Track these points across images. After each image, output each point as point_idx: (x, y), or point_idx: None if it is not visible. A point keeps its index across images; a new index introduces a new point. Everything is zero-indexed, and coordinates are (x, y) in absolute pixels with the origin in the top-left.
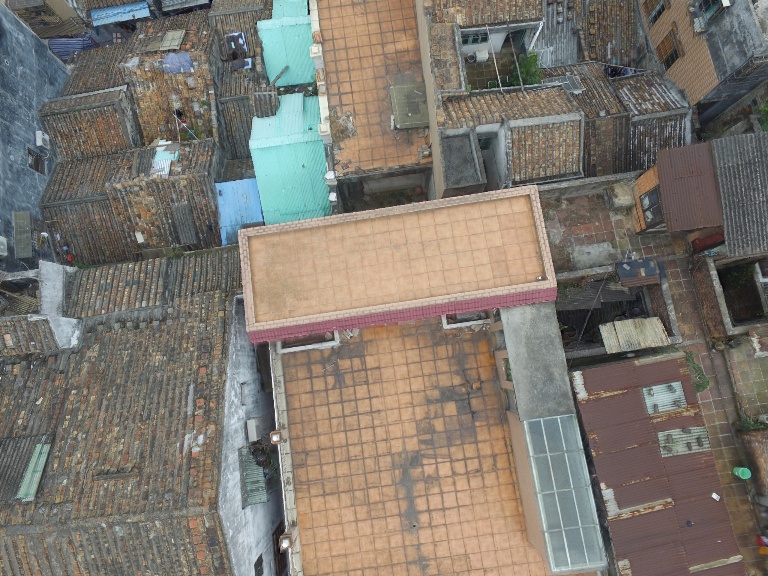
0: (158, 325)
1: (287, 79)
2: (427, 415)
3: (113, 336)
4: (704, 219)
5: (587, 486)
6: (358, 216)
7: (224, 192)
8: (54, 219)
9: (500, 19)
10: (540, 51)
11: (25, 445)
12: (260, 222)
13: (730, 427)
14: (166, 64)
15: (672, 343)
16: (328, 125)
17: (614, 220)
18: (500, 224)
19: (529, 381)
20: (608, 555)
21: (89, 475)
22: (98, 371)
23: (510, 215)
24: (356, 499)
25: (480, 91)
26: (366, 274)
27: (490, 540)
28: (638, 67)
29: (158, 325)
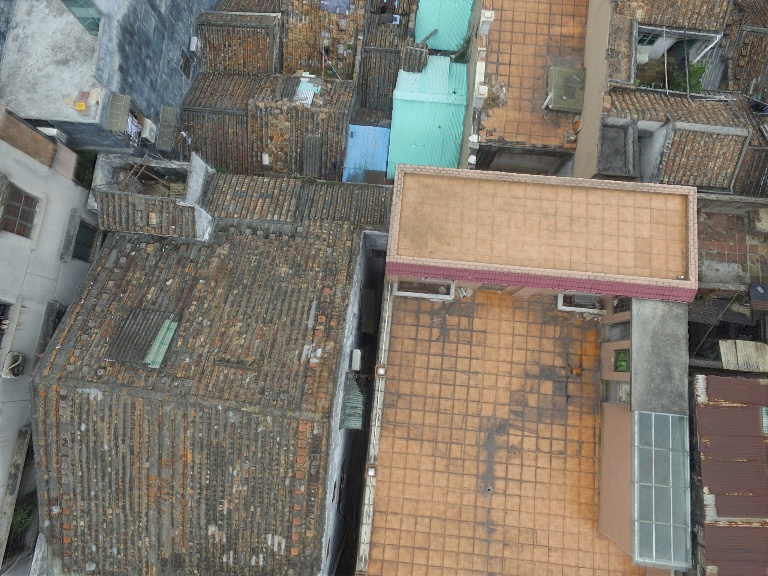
0: (287, 240)
1: (432, 42)
2: (523, 388)
3: (243, 240)
4: None
5: (686, 488)
6: (515, 177)
7: (355, 135)
8: (190, 123)
9: (679, 24)
10: None
11: (154, 318)
12: (383, 171)
13: None
14: (324, 1)
15: None
16: (487, 89)
17: (750, 244)
18: (652, 217)
19: (648, 374)
20: (694, 558)
21: (211, 359)
22: (226, 268)
23: (663, 211)
24: (438, 450)
25: (645, 89)
26: (510, 234)
27: (560, 521)
28: None
29: (287, 240)
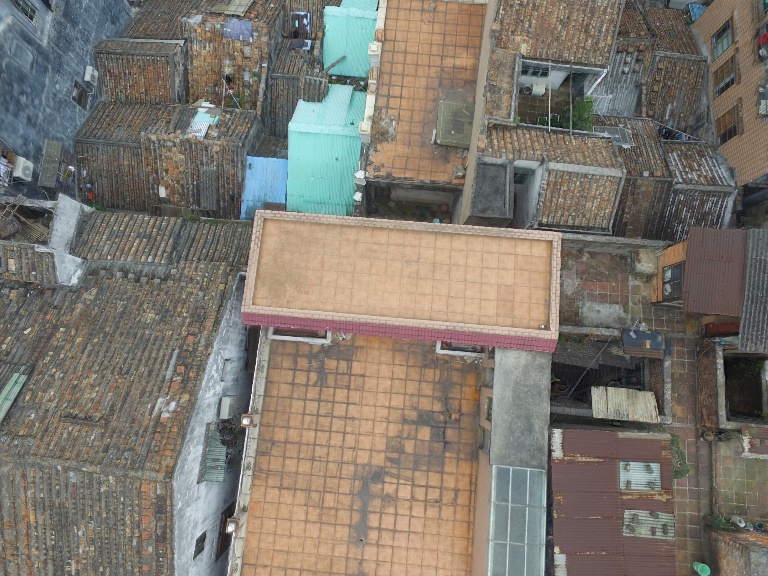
0: (158, 283)
1: (341, 69)
2: (400, 434)
3: (113, 284)
4: (723, 306)
5: (541, 545)
6: (377, 223)
7: (254, 166)
8: (84, 155)
9: (565, 58)
10: (599, 96)
11: (3, 371)
12: (282, 204)
13: (700, 520)
14: (227, 28)
15: (661, 422)
16: (369, 125)
17: (632, 284)
18: (516, 263)
19: (508, 426)
20: None
21: (57, 415)
22: (90, 315)
23: (528, 257)
24: (311, 499)
25: (528, 125)
26: (371, 282)
27: (433, 572)
28: (693, 134)
29: (158, 283)
